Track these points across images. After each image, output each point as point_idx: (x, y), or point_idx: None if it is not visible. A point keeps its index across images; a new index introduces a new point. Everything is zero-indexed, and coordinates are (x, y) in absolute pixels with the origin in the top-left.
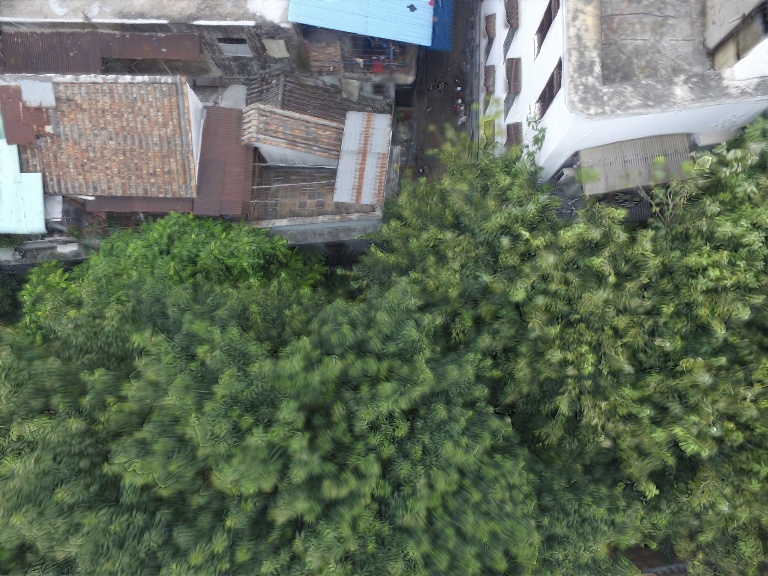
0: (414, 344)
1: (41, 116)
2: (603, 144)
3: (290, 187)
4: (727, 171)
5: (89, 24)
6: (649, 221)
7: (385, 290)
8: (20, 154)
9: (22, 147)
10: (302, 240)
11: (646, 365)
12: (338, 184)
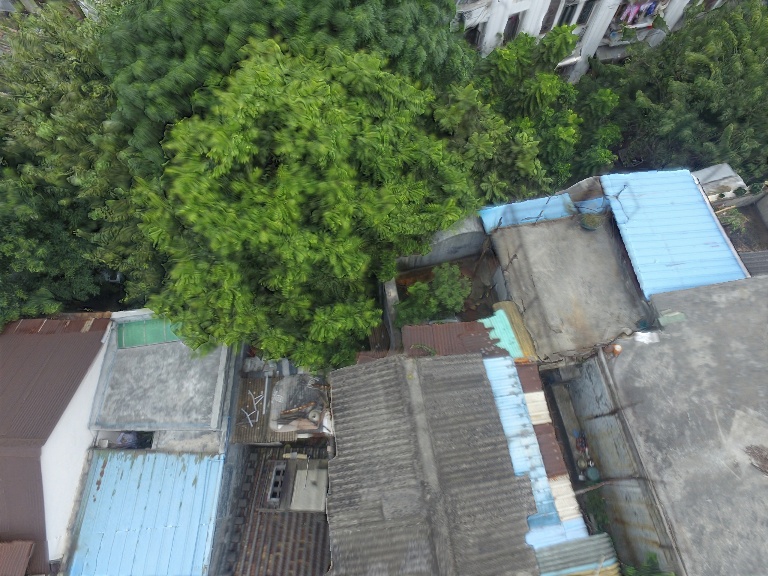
0: None
1: None
2: None
3: None
4: None
5: None
6: None
7: None
8: None
9: None
10: None
11: None
12: None
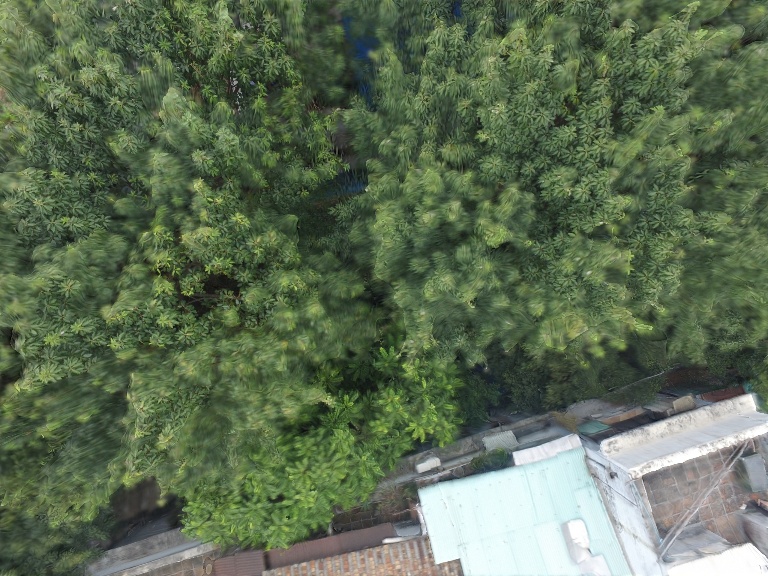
0: None
1: None
2: None
3: None
4: None
5: None
6: None
7: (25, 510)
8: None
9: None
10: None
11: None
12: None
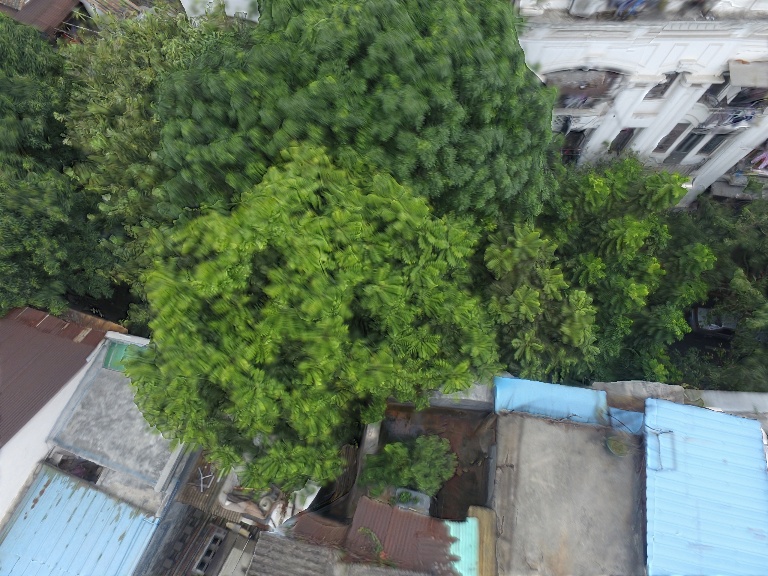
0: (4, 53)
1: None
2: None
3: None
4: (209, 5)
5: None
6: None
7: None
8: None
9: None
10: None
11: None
12: None
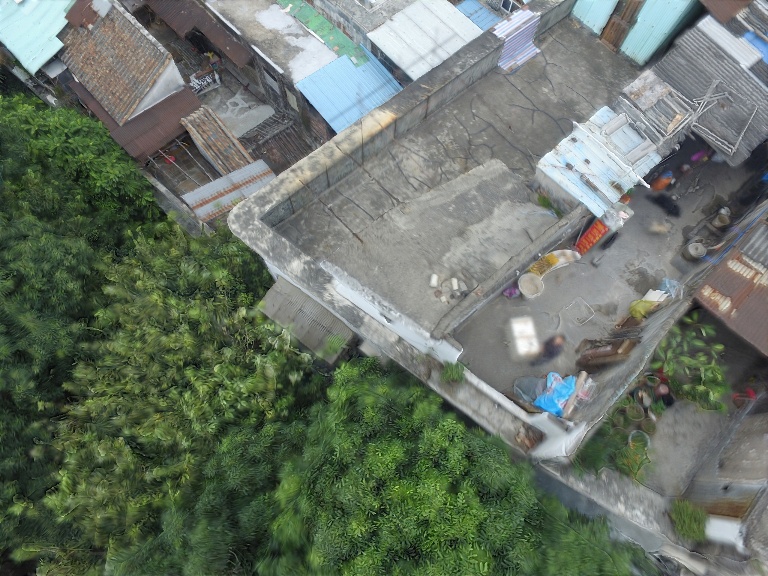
0: (29, 276)
1: (93, 17)
2: (290, 282)
3: (201, 178)
4: (269, 340)
5: (203, 3)
6: (232, 342)
7: None
8: (66, 27)
9: (71, 25)
10: (170, 213)
11: (140, 440)
12: (198, 190)
